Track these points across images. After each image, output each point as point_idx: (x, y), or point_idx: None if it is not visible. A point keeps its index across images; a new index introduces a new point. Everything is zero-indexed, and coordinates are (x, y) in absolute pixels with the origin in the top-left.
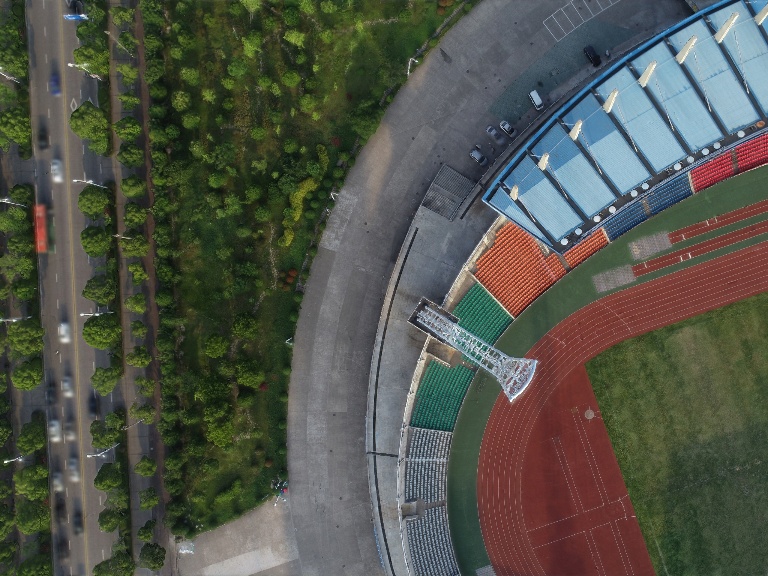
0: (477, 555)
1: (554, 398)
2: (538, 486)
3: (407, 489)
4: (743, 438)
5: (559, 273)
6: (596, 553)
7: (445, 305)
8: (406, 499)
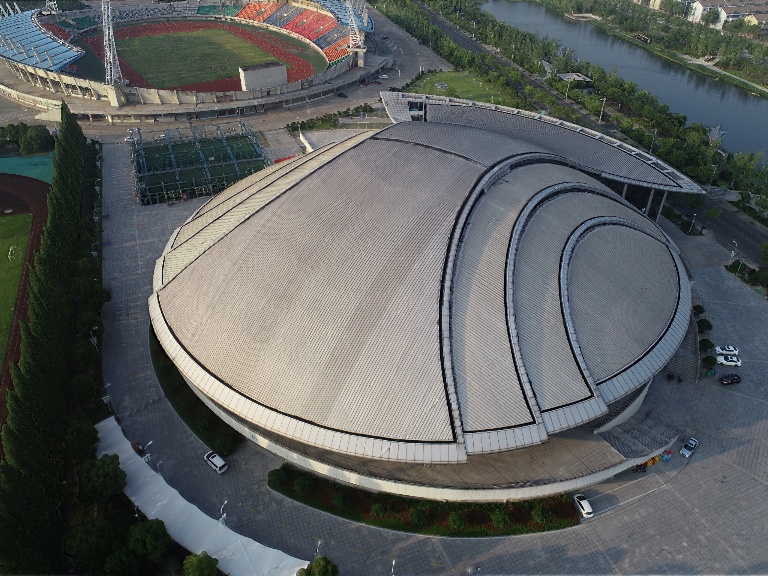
0: None
1: None
2: None
3: (178, 7)
4: None
5: None
6: None
7: (237, 2)
8: (175, 7)
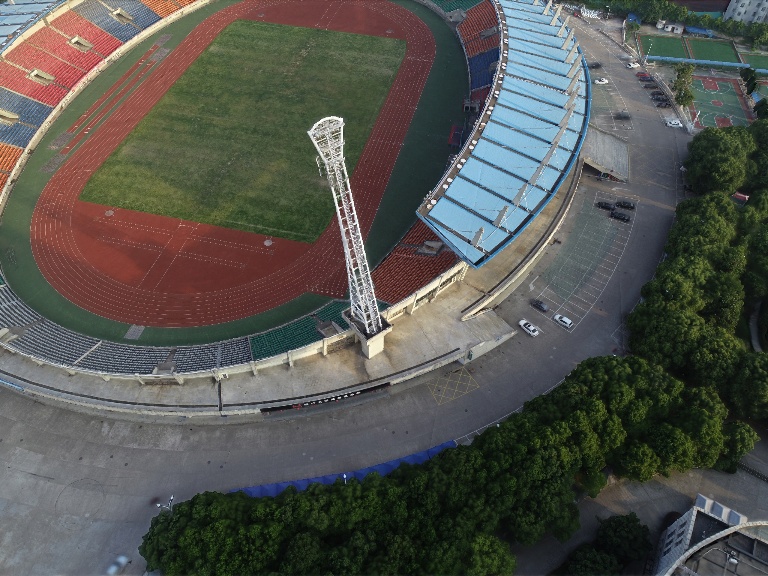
0: (114, 330)
1: (76, 225)
2: (116, 264)
3: None
4: (214, 153)
5: (4, 177)
6: (199, 256)
7: None
8: None
